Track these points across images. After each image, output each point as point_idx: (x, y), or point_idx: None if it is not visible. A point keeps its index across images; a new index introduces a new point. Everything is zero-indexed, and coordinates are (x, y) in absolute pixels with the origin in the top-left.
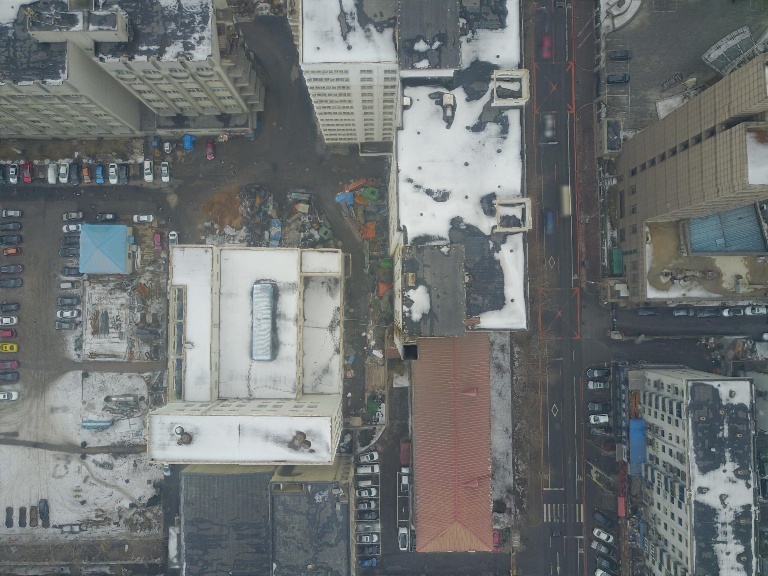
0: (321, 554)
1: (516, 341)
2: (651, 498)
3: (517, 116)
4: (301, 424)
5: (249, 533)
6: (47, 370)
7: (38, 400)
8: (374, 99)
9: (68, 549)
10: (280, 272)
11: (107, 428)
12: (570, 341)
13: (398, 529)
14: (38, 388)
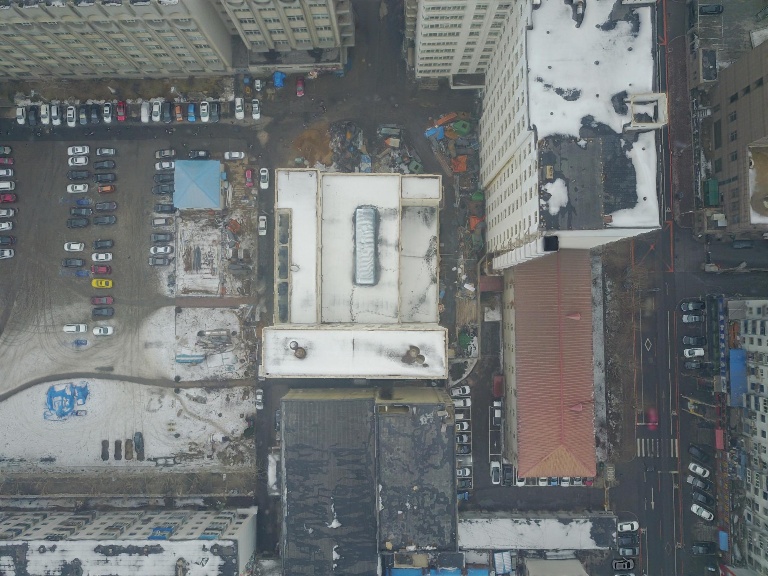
0: (427, 476)
1: (608, 275)
2: (753, 428)
3: (648, 14)
4: (415, 338)
5: (350, 459)
6: (141, 306)
7: (132, 335)
8: (486, 14)
9: (162, 482)
10: (381, 198)
11: (201, 362)
12: (663, 275)
13: (490, 463)
14: (132, 323)
